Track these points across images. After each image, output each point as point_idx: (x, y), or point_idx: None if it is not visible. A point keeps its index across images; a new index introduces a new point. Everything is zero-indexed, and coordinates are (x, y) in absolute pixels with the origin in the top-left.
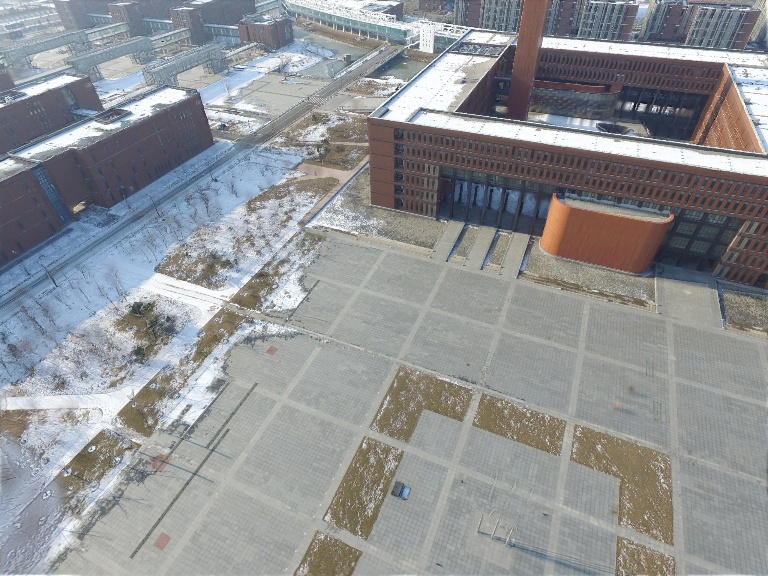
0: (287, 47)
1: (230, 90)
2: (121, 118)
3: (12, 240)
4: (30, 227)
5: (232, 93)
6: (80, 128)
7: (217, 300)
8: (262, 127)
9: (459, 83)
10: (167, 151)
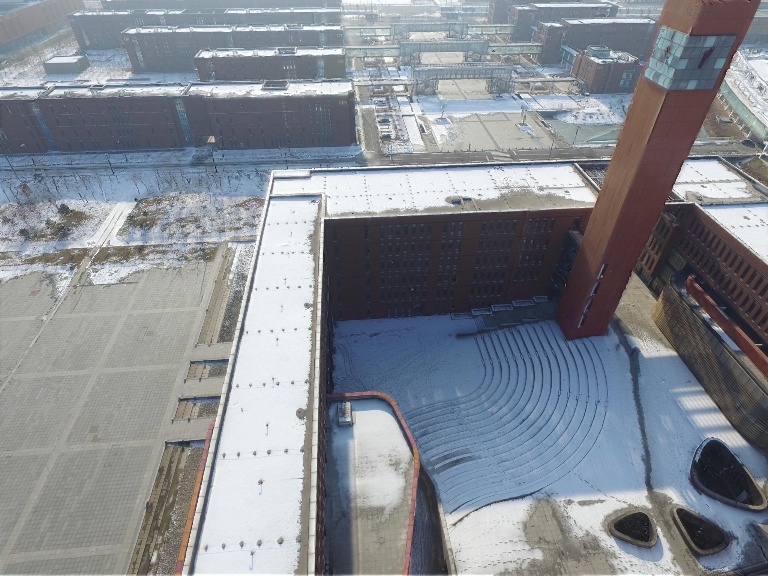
0: (611, 95)
1: (465, 111)
2: (274, 90)
3: (145, 136)
4: (159, 134)
5: (460, 114)
6: (247, 85)
7: (102, 241)
8: (406, 153)
9: (451, 200)
10: (290, 130)
